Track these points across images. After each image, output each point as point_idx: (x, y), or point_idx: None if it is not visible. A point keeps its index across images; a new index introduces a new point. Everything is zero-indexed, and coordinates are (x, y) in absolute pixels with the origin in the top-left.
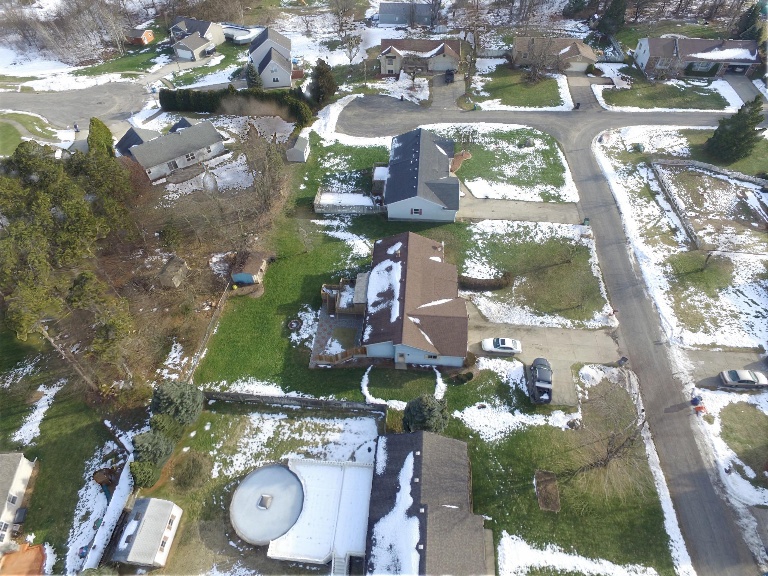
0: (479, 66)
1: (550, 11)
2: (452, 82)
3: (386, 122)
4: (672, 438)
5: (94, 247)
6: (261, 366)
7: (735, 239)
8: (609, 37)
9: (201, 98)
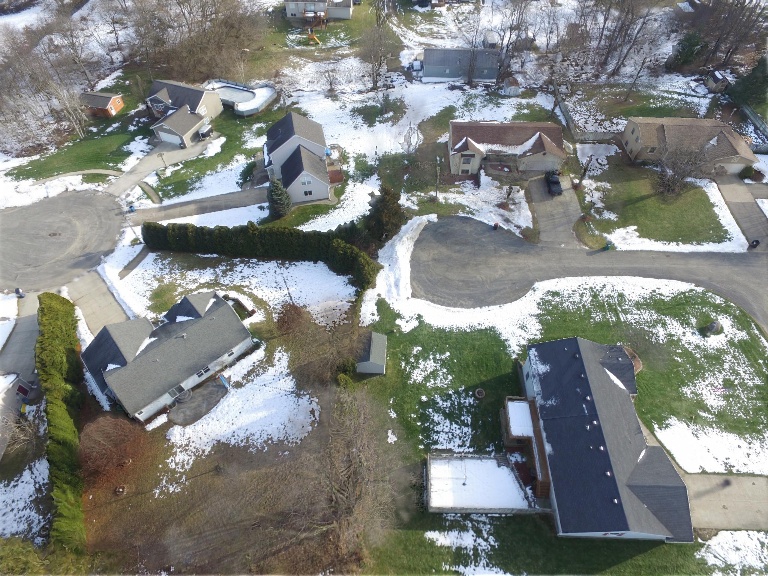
0: (584, 159)
1: (641, 57)
2: (559, 195)
3: (484, 275)
4: None
5: None
6: None
7: None
8: (742, 107)
9: (205, 237)
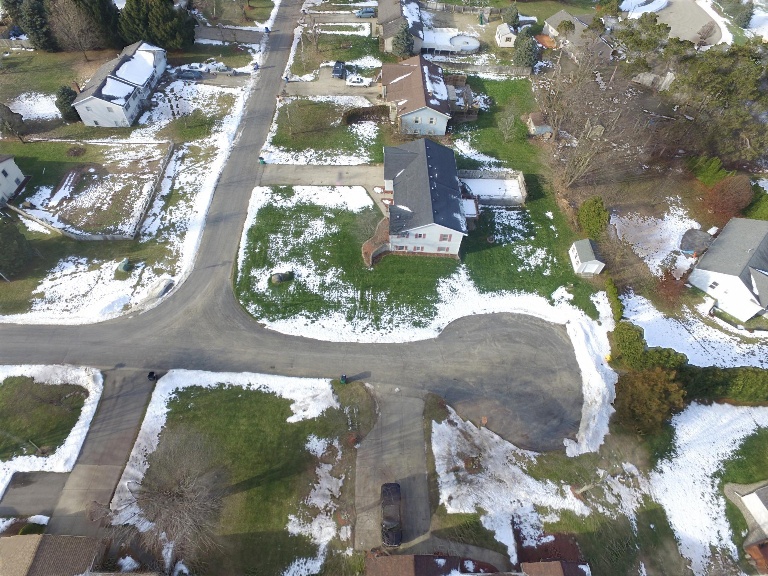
0: None
1: None
2: None
3: (494, 348)
4: (279, 59)
5: None
6: (497, 85)
7: (130, 155)
8: None
9: None
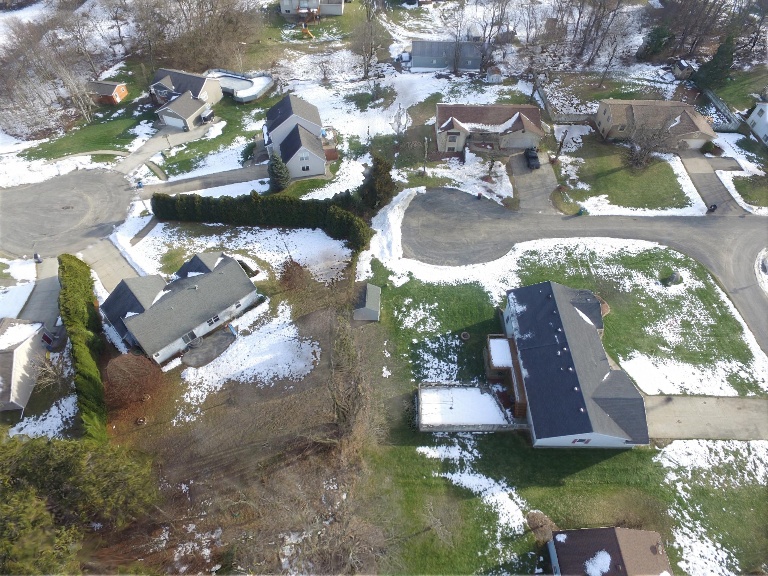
0: (560, 138)
1: None
2: (538, 168)
3: (469, 238)
4: None
5: (88, 525)
6: None
7: None
8: (706, 92)
9: (211, 207)
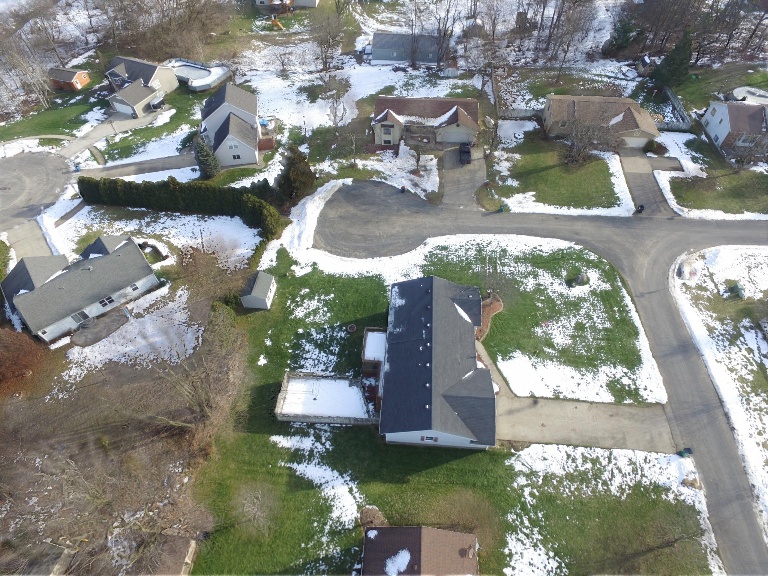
0: (502, 134)
1: (584, 44)
2: (469, 163)
3: (382, 231)
4: None
5: None
6: None
7: None
8: (665, 89)
9: (133, 191)
